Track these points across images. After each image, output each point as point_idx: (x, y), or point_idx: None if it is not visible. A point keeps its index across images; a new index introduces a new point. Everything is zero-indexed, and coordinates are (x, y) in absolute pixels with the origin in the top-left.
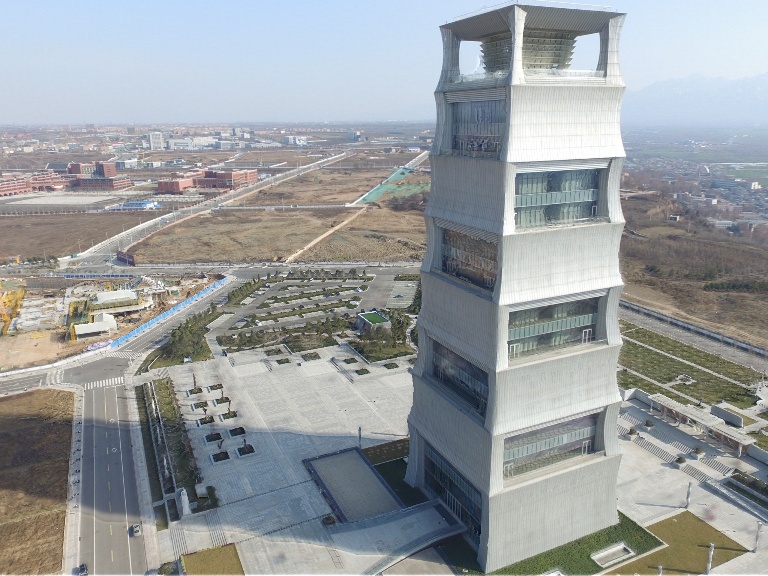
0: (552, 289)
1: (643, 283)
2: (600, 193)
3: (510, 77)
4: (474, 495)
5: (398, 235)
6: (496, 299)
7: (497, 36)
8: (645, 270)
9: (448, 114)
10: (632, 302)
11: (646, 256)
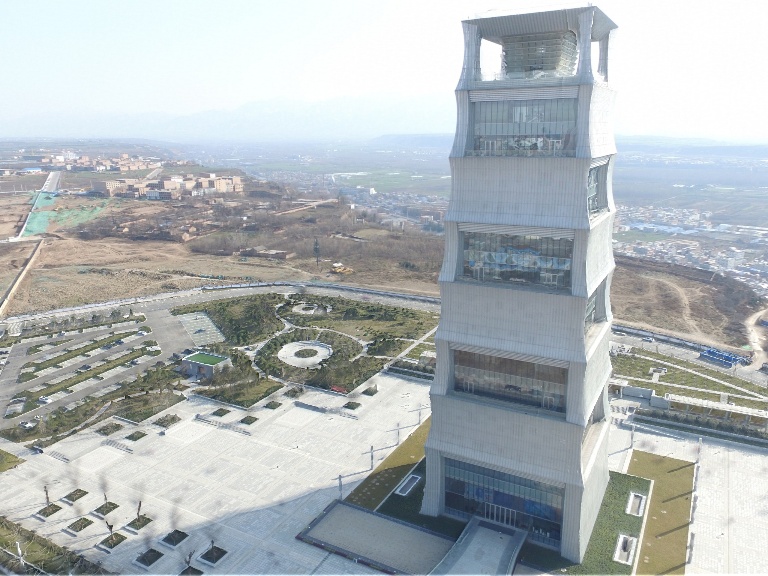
0: (599, 277)
1: (413, 278)
2: (600, 186)
3: (589, 76)
4: (540, 495)
5: (121, 266)
6: (580, 293)
7: (533, 36)
8: (401, 267)
9: (471, 113)
10: (423, 295)
11: (391, 255)
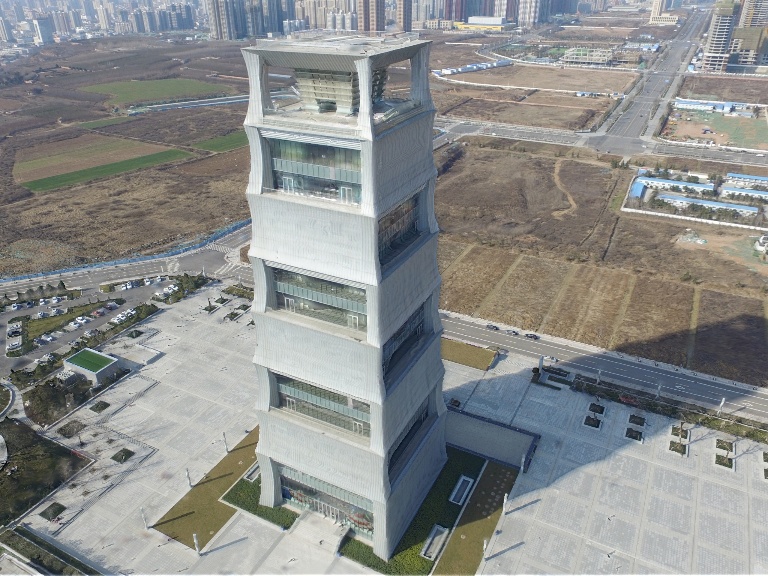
0: None
1: None
2: None
3: None
4: None
5: None
6: None
7: None
8: None
9: None
10: None
11: None
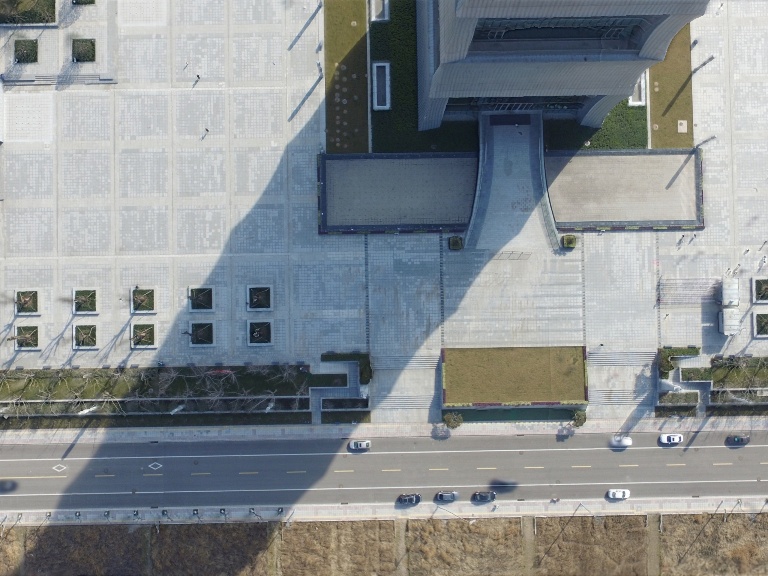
0: None
1: None
2: None
3: None
4: None
5: None
6: None
7: None
8: None
9: None
10: None
11: None
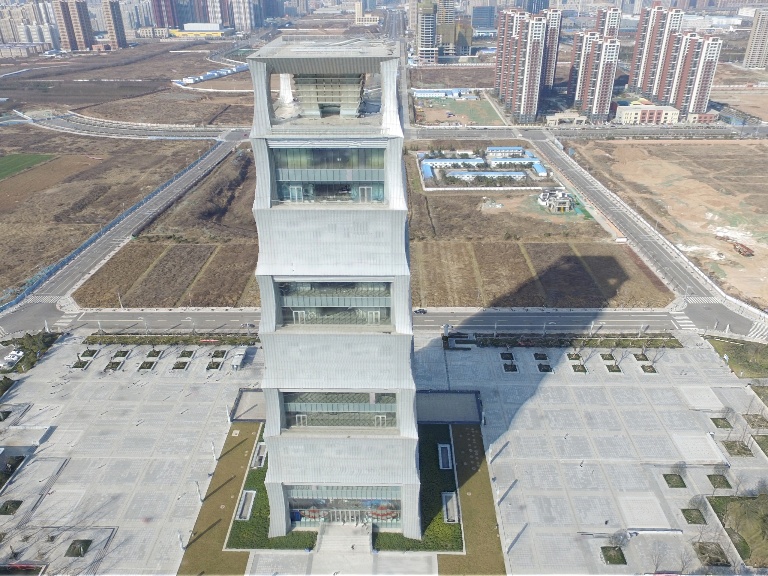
0: None
1: None
2: None
3: None
4: None
5: None
6: None
7: None
8: None
9: None
10: None
11: None
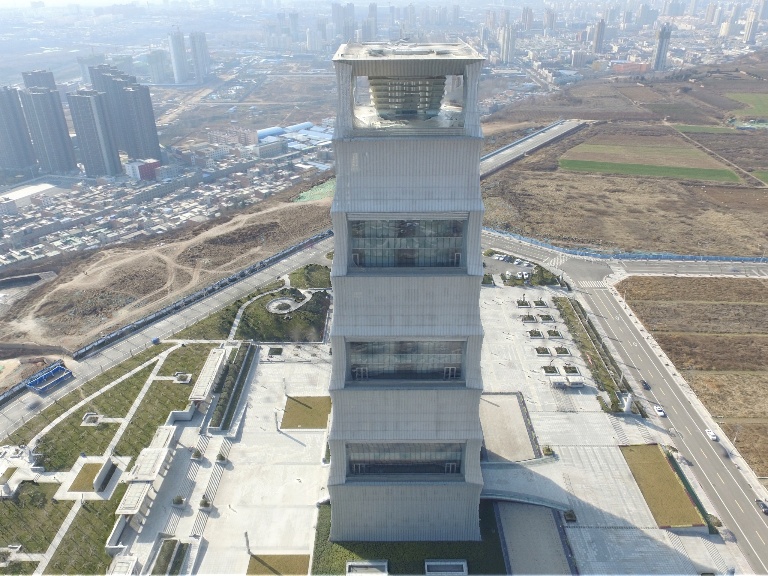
0: None
1: None
2: None
3: None
4: None
5: None
6: None
7: None
8: None
9: None
10: None
11: None
